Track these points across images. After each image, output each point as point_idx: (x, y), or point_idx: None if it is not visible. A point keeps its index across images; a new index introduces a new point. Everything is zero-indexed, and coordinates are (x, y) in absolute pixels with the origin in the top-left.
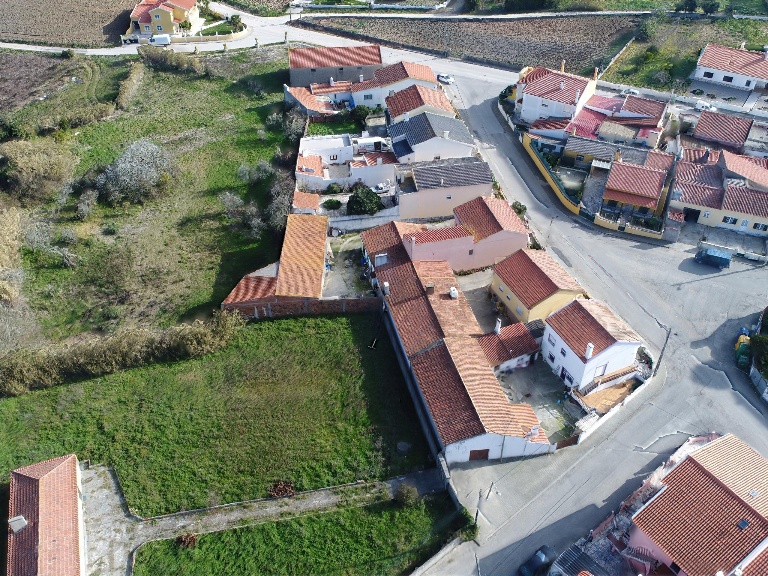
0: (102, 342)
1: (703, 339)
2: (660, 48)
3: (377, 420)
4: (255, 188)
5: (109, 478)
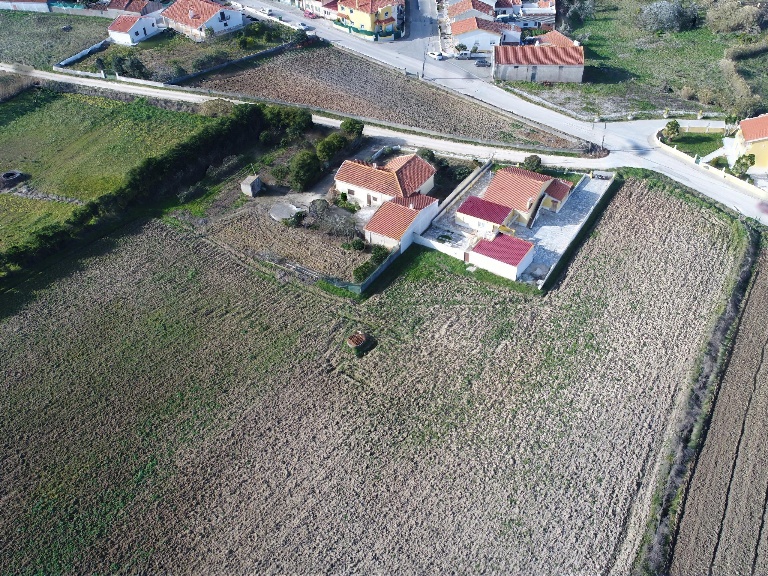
0: None
1: None
2: None
3: None
4: None
5: None
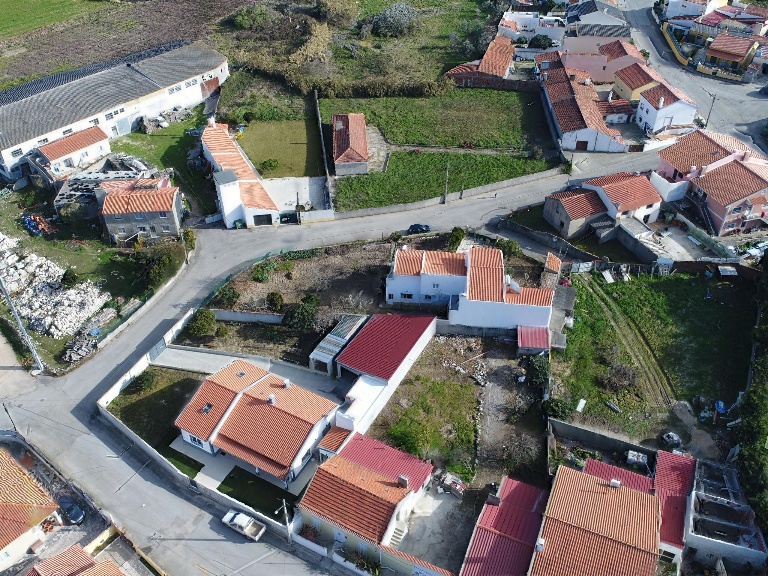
0: (378, 78)
1: (745, 123)
2: None
3: (526, 131)
4: (469, 38)
5: (378, 130)
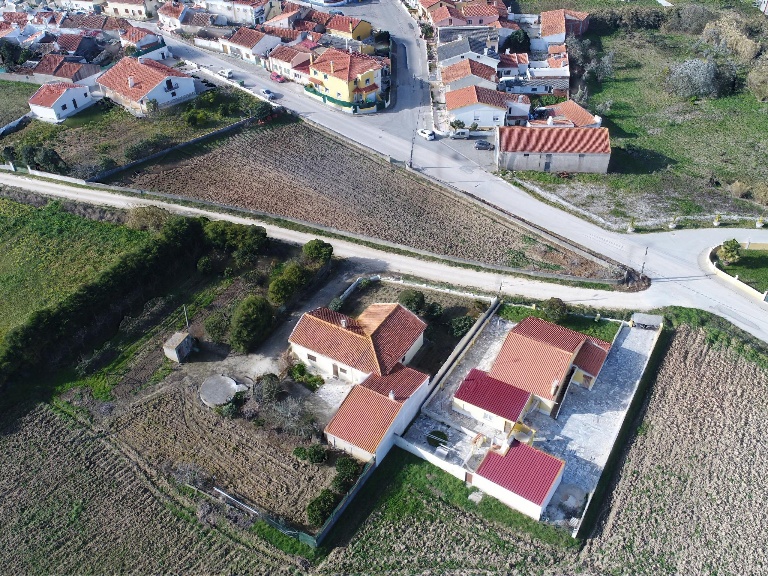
0: None
1: (372, 4)
2: (169, 132)
3: None
4: None
5: None
